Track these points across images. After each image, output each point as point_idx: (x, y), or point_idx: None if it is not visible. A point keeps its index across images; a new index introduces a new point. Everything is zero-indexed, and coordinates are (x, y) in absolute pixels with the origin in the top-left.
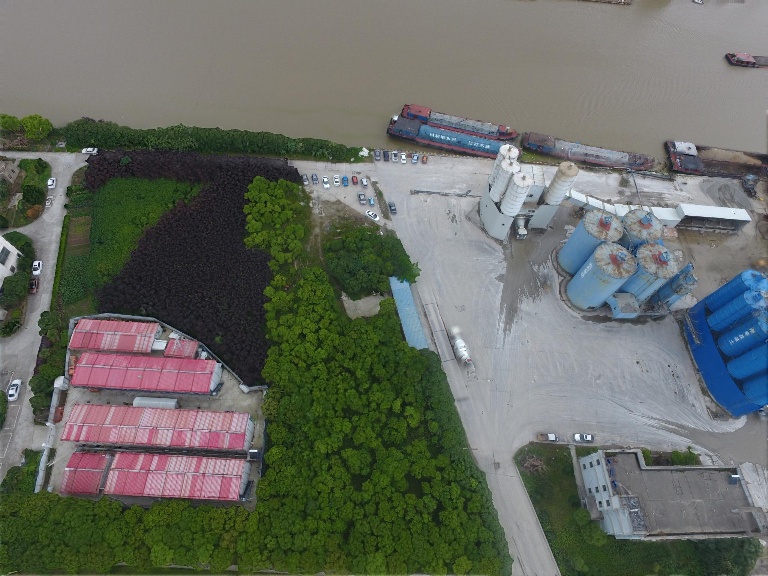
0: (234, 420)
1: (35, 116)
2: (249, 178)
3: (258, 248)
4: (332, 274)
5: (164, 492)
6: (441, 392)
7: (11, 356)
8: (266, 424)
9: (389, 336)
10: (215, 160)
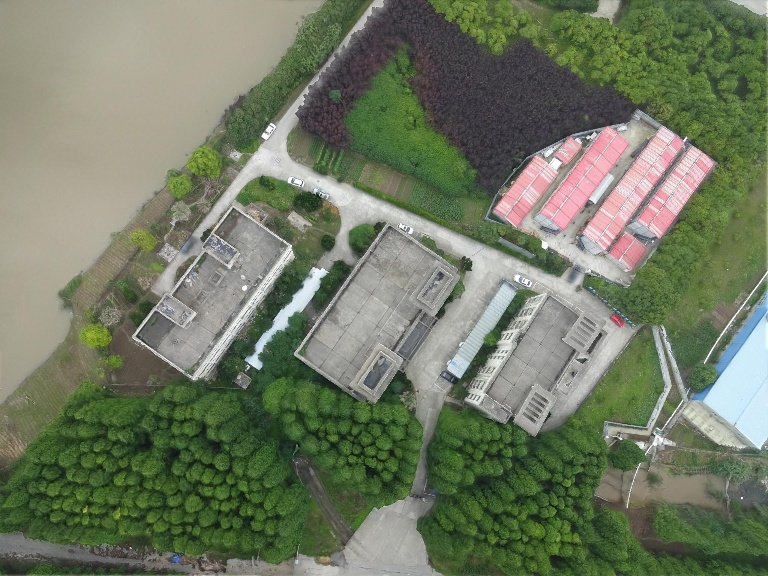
0: (661, 137)
1: (200, 153)
2: (428, 4)
3: (503, 47)
4: (574, 6)
5: (682, 203)
6: (719, 0)
7: (487, 276)
8: (666, 125)
9: (663, 1)
10: (384, 20)
